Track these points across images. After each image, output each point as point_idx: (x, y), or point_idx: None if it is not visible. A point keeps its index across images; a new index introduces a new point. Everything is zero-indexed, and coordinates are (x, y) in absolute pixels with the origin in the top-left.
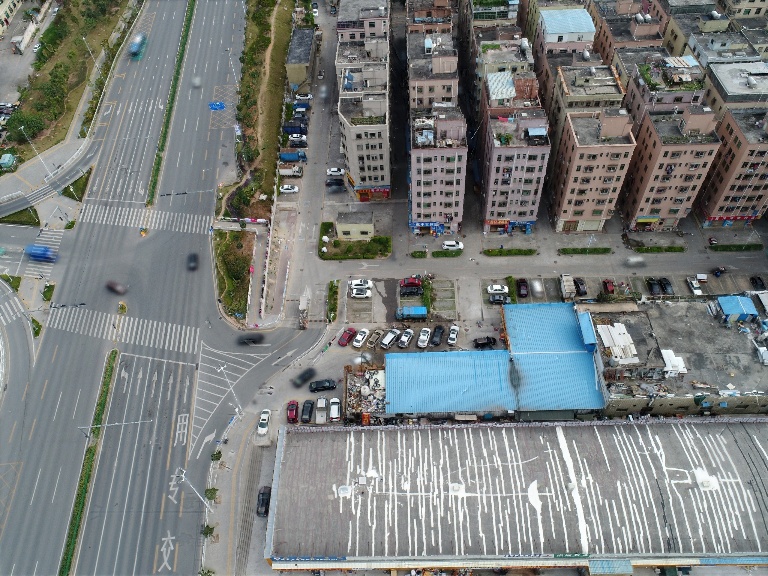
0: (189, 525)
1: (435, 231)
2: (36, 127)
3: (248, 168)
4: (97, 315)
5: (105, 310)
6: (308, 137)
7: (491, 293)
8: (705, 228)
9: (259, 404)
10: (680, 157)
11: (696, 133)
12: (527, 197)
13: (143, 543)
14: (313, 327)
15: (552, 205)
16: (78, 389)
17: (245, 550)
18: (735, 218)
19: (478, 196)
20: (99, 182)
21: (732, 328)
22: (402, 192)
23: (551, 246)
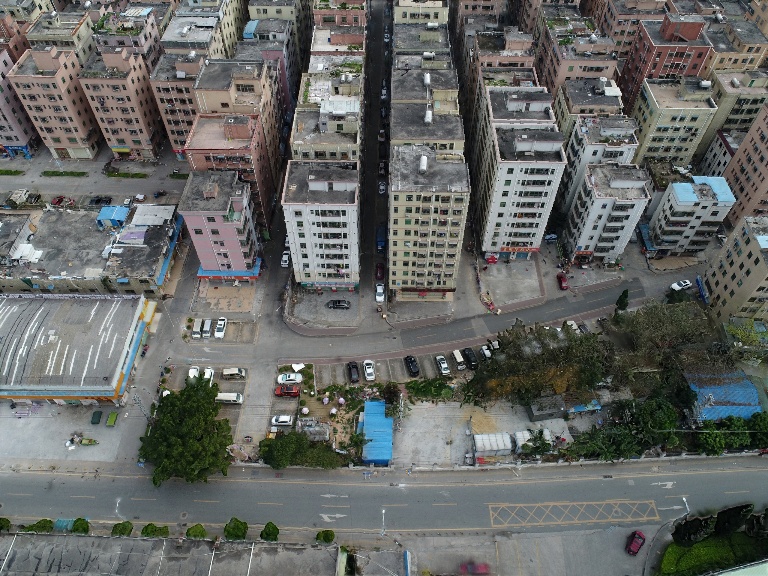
0: None
1: None
2: None
3: None
4: None
5: None
6: None
7: None
8: (179, 160)
9: None
10: (101, 90)
11: (111, 70)
12: (1, 122)
13: None
14: None
15: None
16: None
17: None
18: None
19: None
20: None
21: (104, 231)
22: None
23: (40, 169)
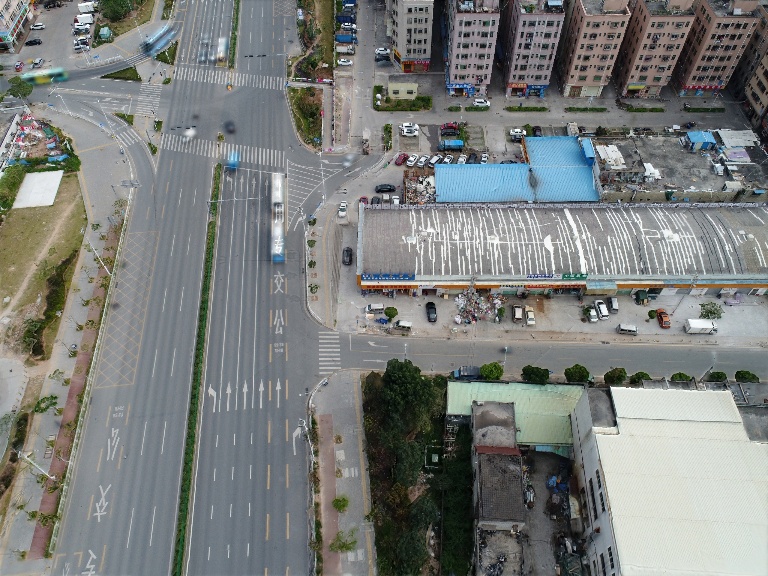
0: (293, 268)
1: (467, 93)
2: (127, 7)
3: (310, 45)
4: (201, 141)
5: (207, 138)
6: (357, 26)
7: (513, 135)
8: (681, 97)
9: (337, 199)
10: (664, 27)
11: (677, 8)
12: (543, 62)
13: (261, 278)
14: (374, 154)
15: (561, 76)
16: (194, 188)
17: (336, 283)
18: (705, 87)
19: (501, 71)
20: (185, 52)
21: (696, 153)
22: (438, 67)
23: (560, 106)
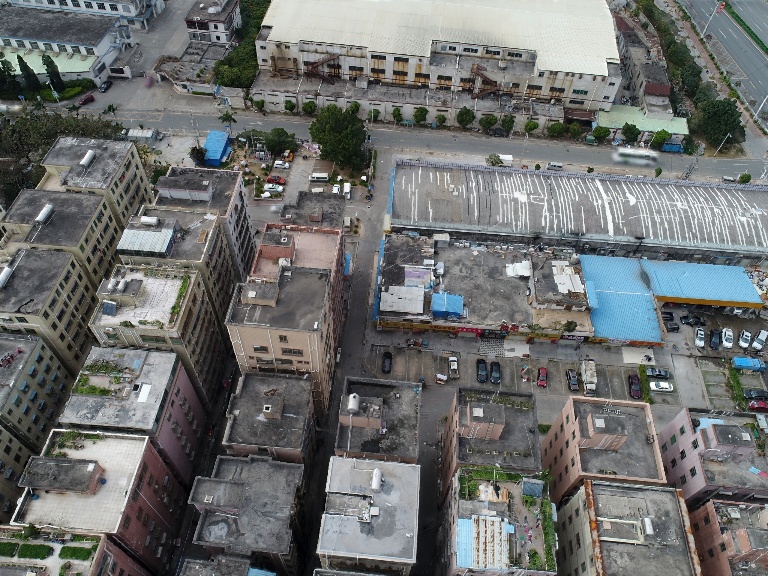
0: None
1: None
2: None
3: None
4: None
5: None
6: None
7: None
8: None
9: None
10: None
11: None
12: None
13: None
14: None
15: None
16: None
17: None
18: None
19: None
20: None
21: None
22: None
23: None
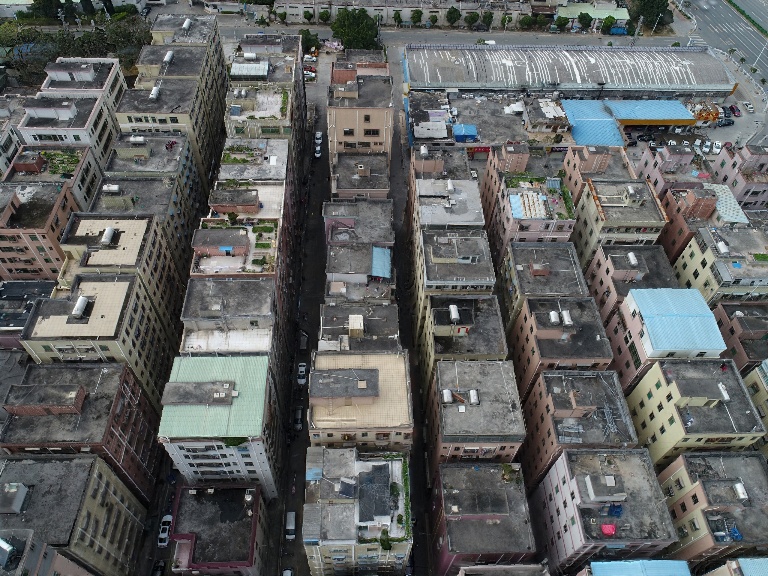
0: (754, 76)
1: None
2: None
3: None
4: None
5: None
6: None
7: None
8: None
9: (759, 117)
10: None
11: None
12: None
13: None
14: None
15: None
16: None
17: None
18: None
19: None
20: None
21: None
22: None
23: None
